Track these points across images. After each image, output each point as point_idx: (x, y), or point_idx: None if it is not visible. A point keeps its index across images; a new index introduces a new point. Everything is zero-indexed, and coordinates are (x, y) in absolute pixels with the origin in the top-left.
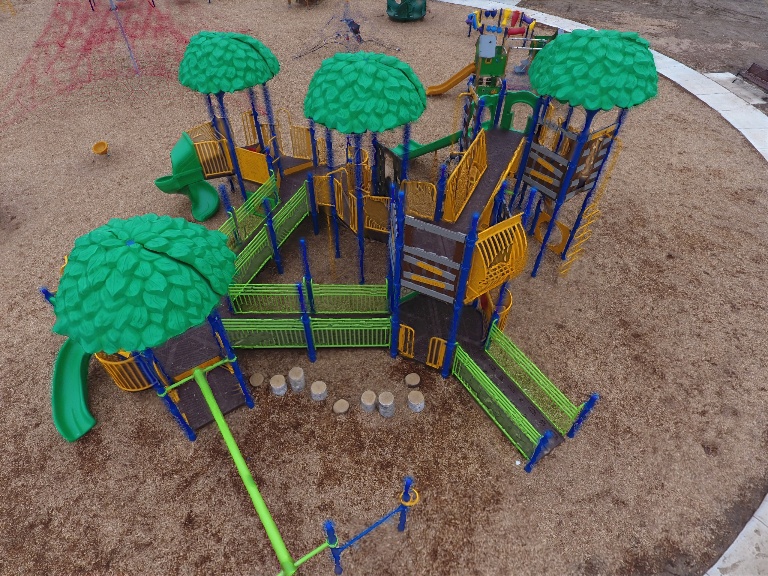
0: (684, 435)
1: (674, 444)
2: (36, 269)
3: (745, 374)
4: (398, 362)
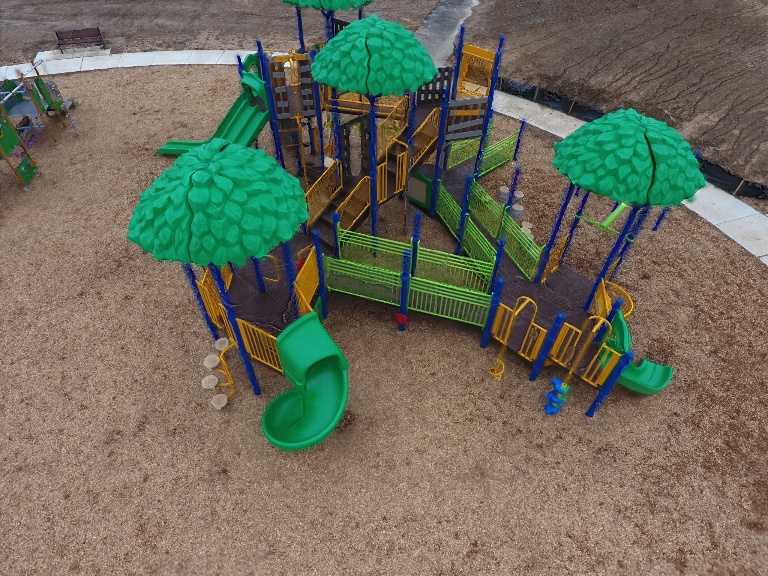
0: None
1: None
2: None
3: None
4: None
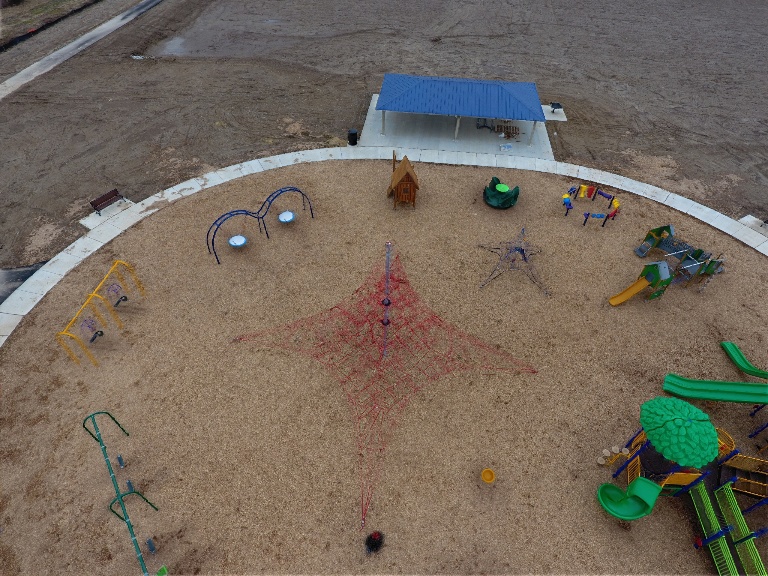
0: None
1: None
2: None
3: None
4: None
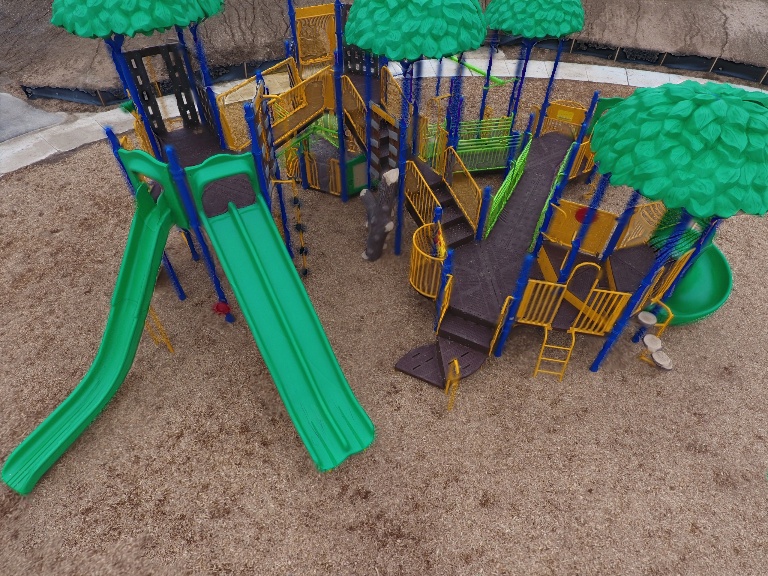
0: None
1: None
2: (760, 232)
3: None
4: None
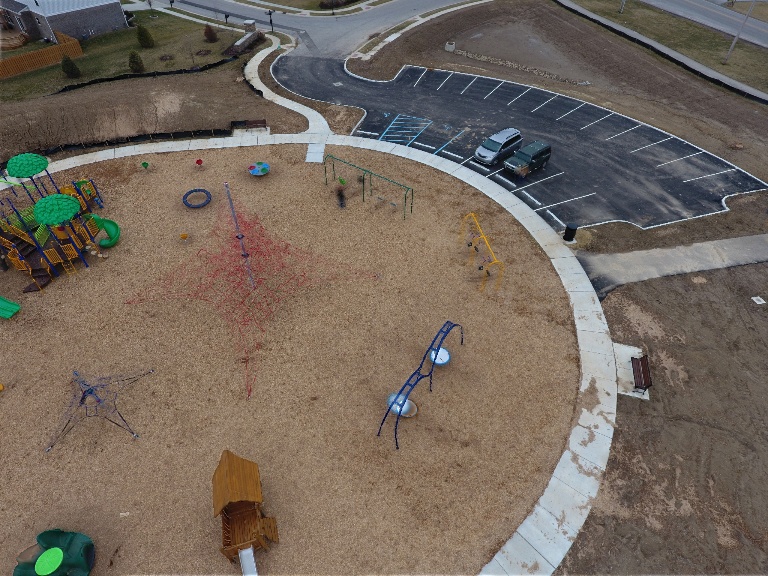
0: None
1: None
2: None
3: None
4: None
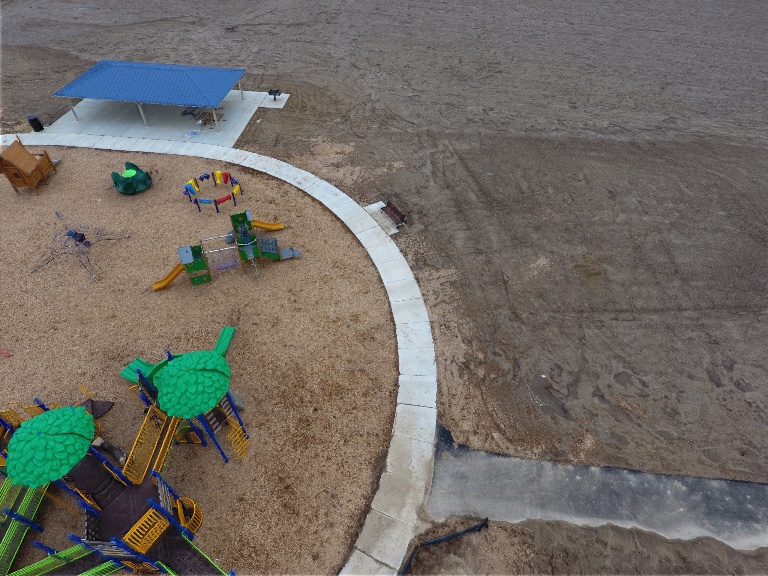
0: (303, 553)
1: (297, 562)
2: None
3: (342, 493)
4: (135, 573)
